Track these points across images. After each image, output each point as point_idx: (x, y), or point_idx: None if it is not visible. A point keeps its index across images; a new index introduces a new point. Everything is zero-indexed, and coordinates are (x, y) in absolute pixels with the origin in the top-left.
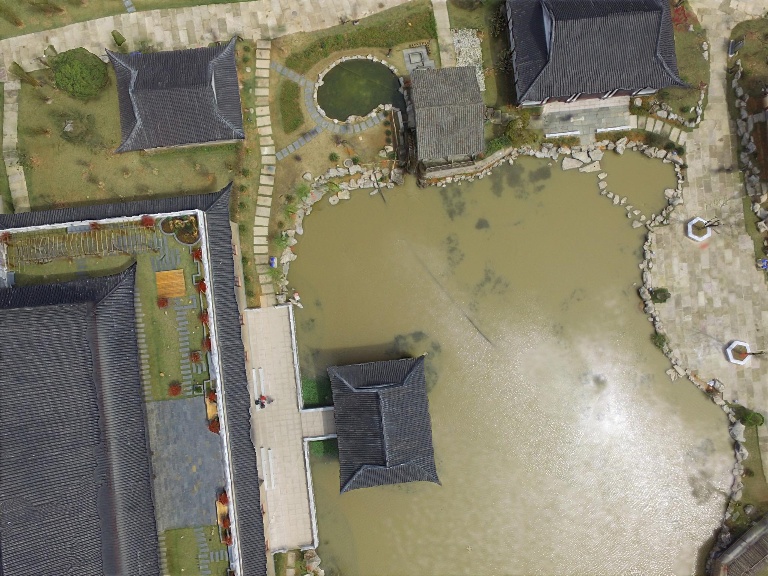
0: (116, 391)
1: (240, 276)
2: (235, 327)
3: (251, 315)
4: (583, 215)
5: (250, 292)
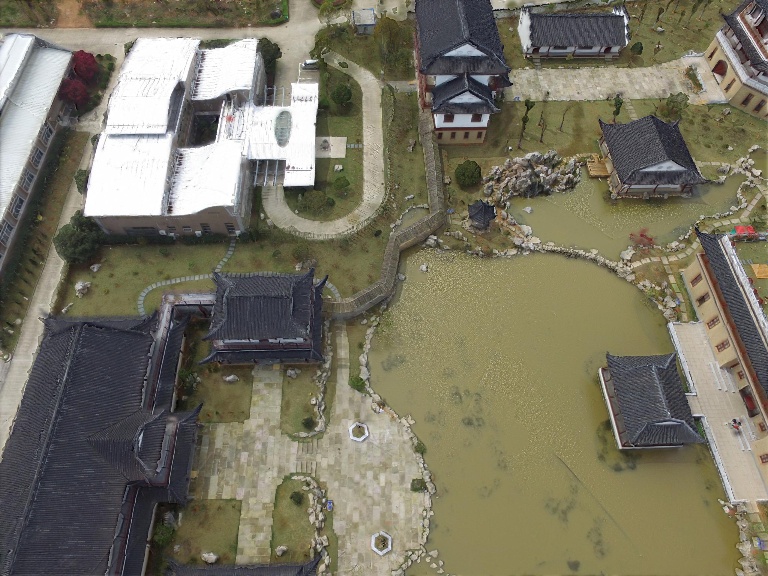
0: None
1: None
2: None
3: (763, 495)
4: (477, 569)
5: None
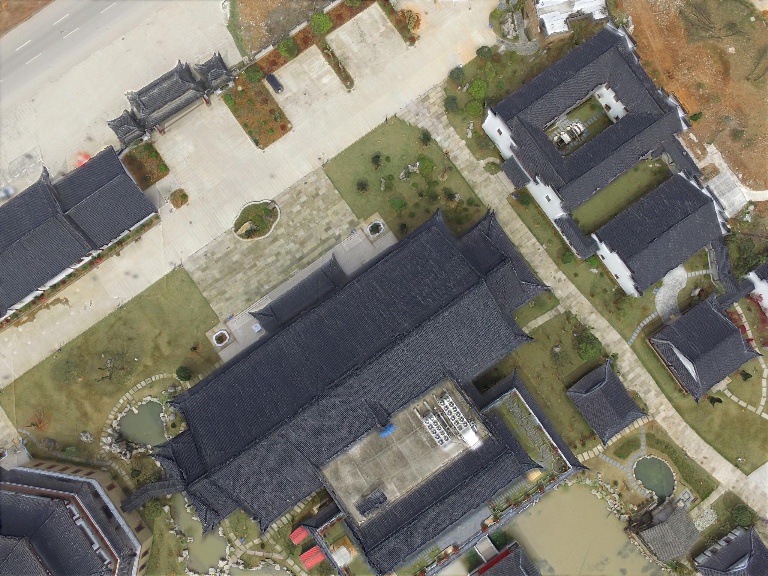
0: None
1: None
2: (526, 505)
3: None
4: None
5: None
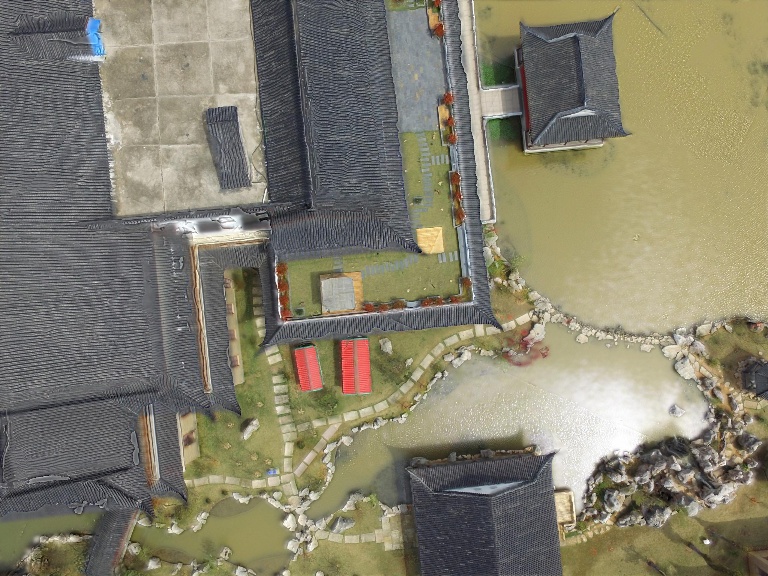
0: None
1: None
2: None
3: None
4: None
5: None
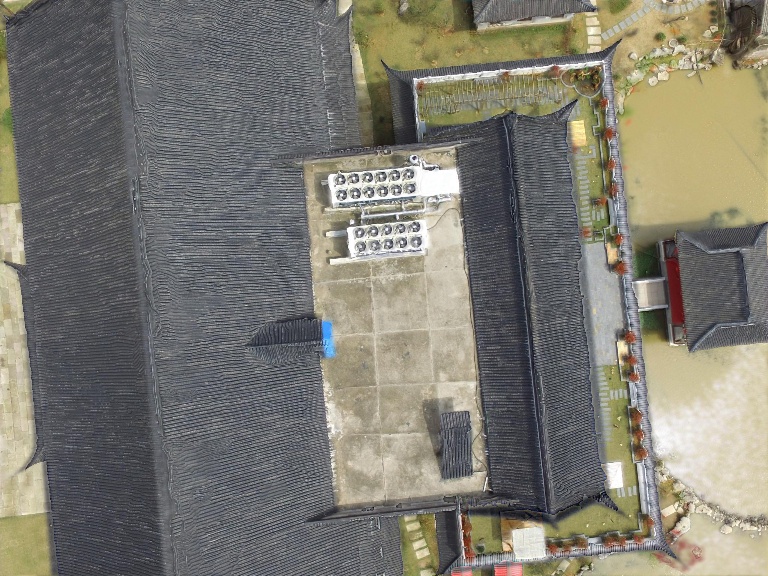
0: None
1: None
2: (620, 181)
3: None
4: None
5: None
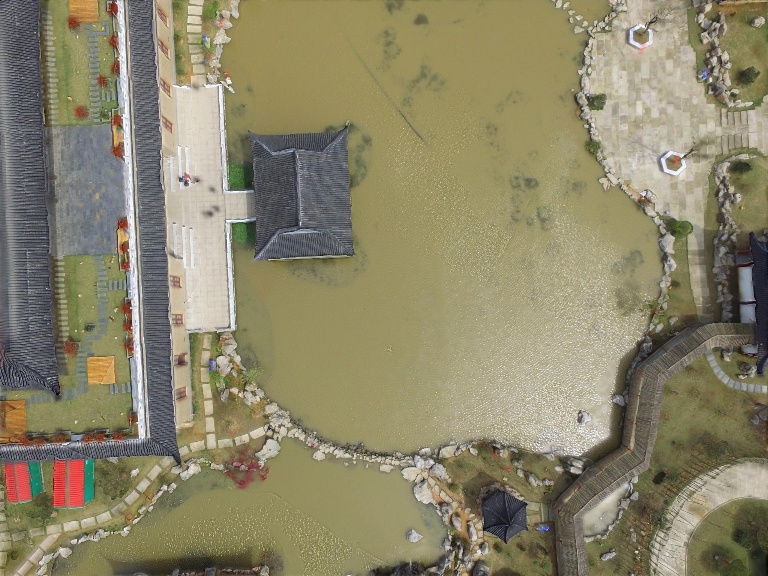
0: (13, 87)
1: (170, 49)
2: (150, 66)
3: (180, 93)
4: (526, 22)
5: (181, 71)
